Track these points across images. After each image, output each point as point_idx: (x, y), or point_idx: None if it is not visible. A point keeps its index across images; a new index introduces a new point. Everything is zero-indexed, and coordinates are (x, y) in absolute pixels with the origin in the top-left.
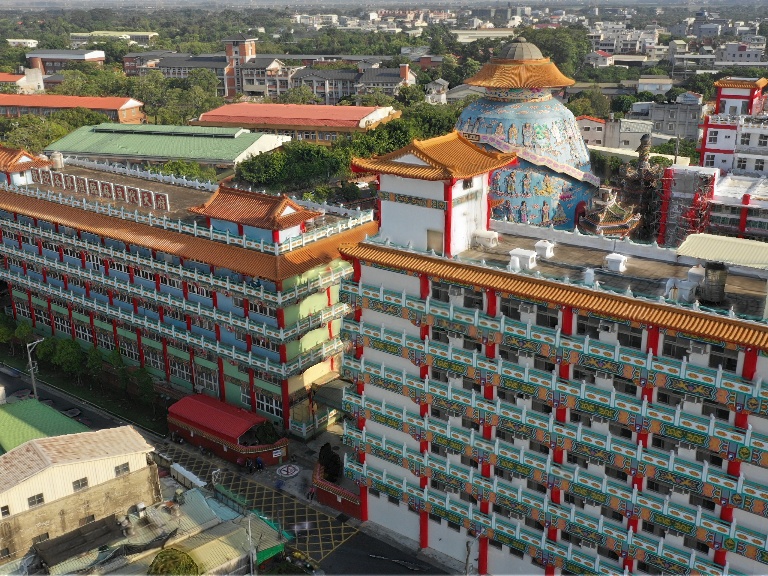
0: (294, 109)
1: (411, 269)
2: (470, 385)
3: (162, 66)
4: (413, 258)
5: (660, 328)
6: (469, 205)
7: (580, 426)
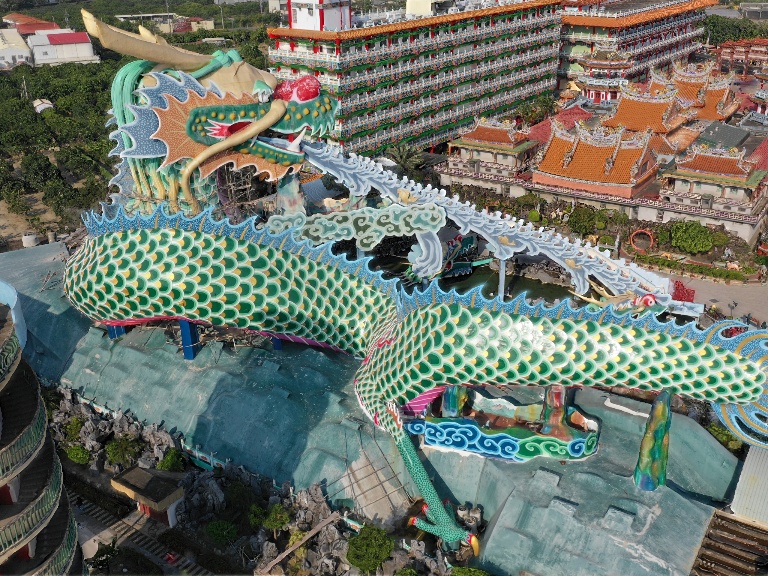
0: None
1: None
2: None
3: None
4: None
5: None
6: None
7: None
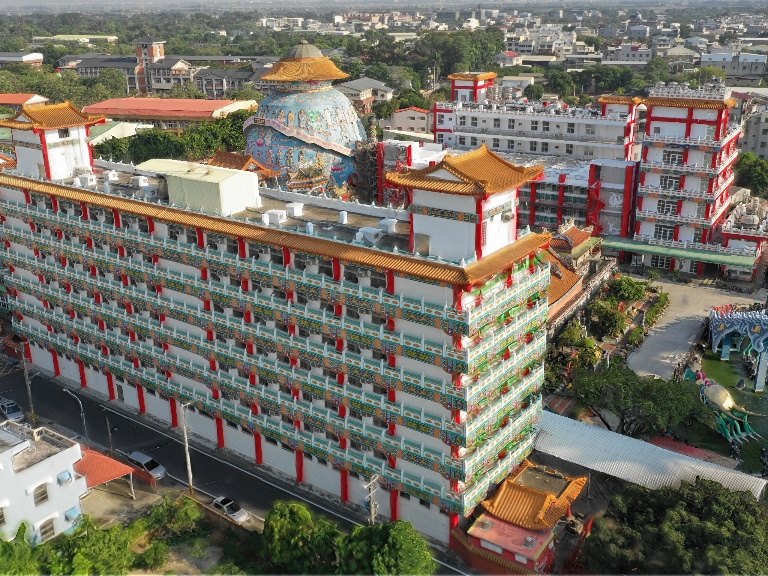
0: (165, 102)
1: (16, 186)
2: (57, 260)
3: (80, 66)
4: (21, 180)
5: (118, 211)
6: (66, 148)
7: (98, 276)
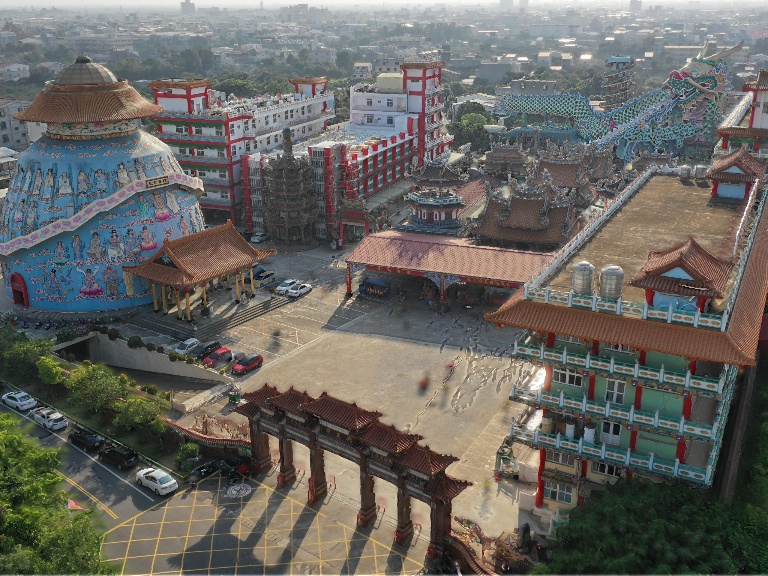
0: None
1: None
2: None
3: None
4: None
5: None
6: None
7: None
